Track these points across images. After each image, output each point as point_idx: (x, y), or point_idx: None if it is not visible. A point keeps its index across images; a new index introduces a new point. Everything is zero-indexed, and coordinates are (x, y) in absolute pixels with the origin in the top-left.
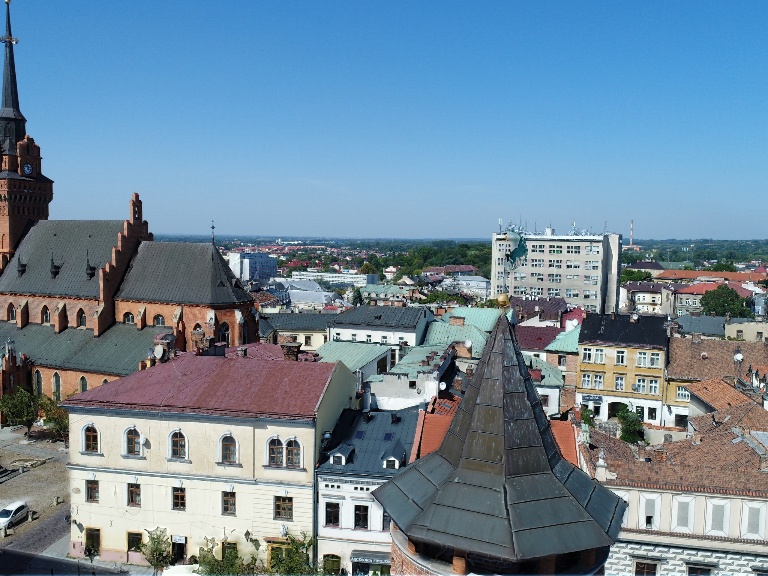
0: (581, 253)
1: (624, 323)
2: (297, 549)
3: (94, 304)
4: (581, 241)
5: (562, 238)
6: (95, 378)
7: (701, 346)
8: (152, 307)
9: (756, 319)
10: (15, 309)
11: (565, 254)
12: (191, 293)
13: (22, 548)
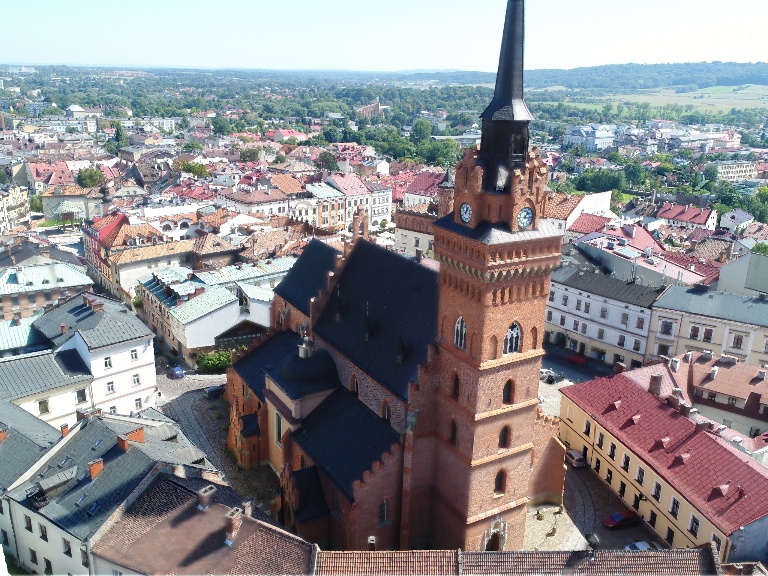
0: None
1: None
2: None
3: None
4: None
5: None
6: None
7: None
8: None
9: None
10: None
11: None
12: None
13: None
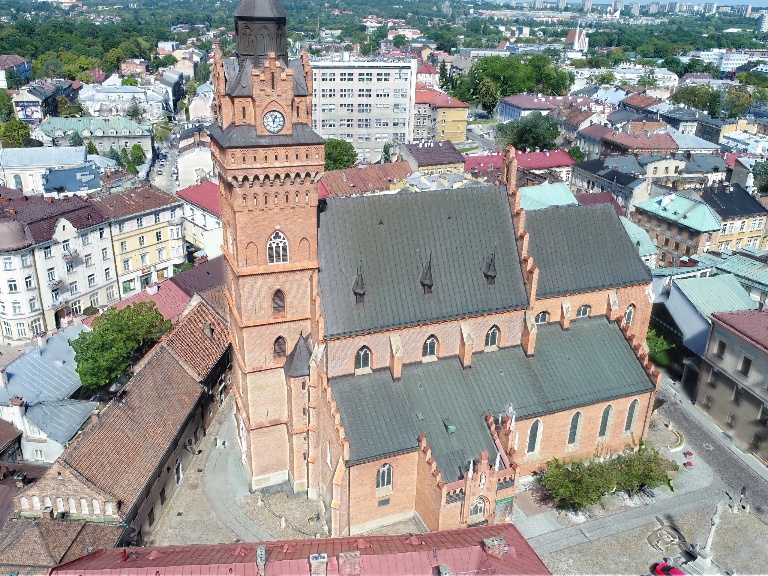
0: (391, 81)
1: (724, 195)
2: None
3: (517, 315)
4: (391, 68)
5: (372, 65)
6: (595, 408)
7: (763, 204)
8: (578, 298)
9: (667, 157)
10: (371, 353)
11: (375, 82)
12: (621, 271)
13: None
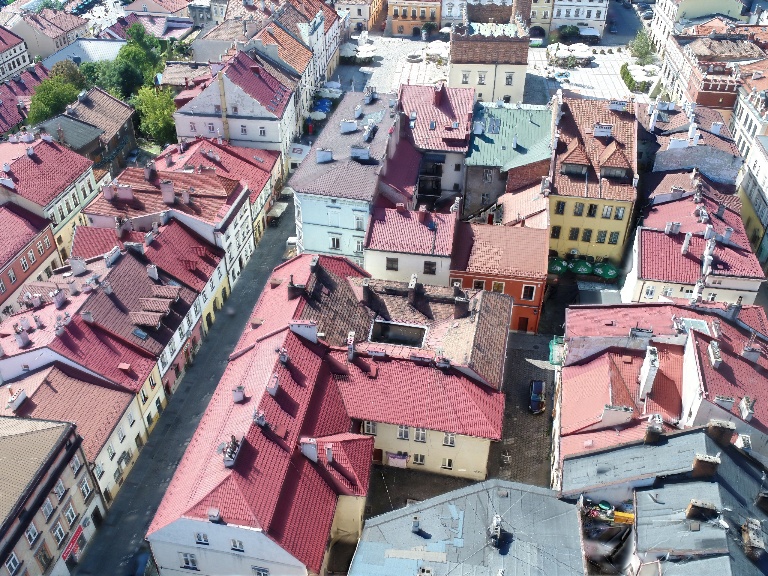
0: None
1: None
2: (644, 39)
3: None
4: None
5: None
6: None
7: None
8: None
9: None
10: None
11: None
12: None
13: (647, 33)
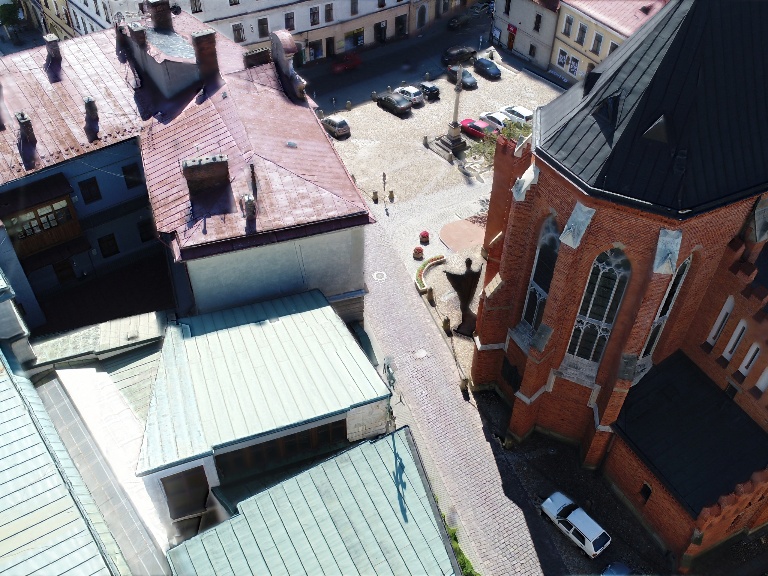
0: None
1: None
2: None
3: None
4: None
5: None
6: None
7: None
8: None
9: None
10: None
11: None
12: None
13: None
